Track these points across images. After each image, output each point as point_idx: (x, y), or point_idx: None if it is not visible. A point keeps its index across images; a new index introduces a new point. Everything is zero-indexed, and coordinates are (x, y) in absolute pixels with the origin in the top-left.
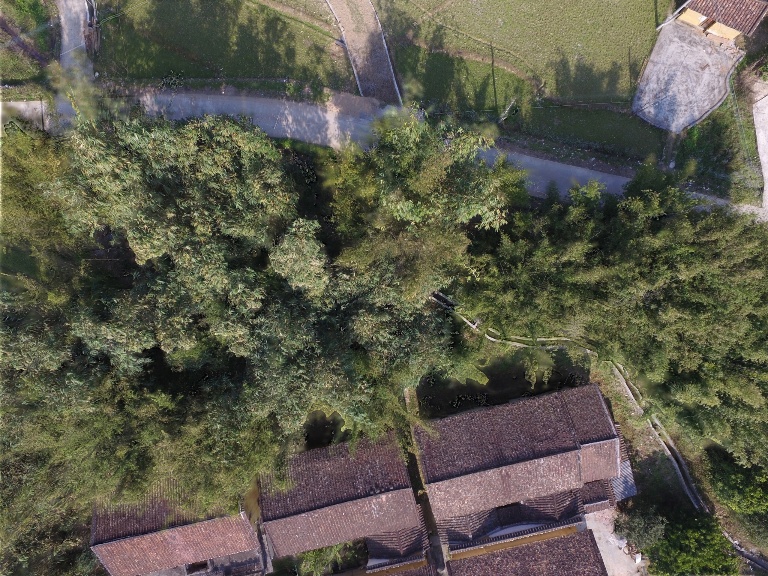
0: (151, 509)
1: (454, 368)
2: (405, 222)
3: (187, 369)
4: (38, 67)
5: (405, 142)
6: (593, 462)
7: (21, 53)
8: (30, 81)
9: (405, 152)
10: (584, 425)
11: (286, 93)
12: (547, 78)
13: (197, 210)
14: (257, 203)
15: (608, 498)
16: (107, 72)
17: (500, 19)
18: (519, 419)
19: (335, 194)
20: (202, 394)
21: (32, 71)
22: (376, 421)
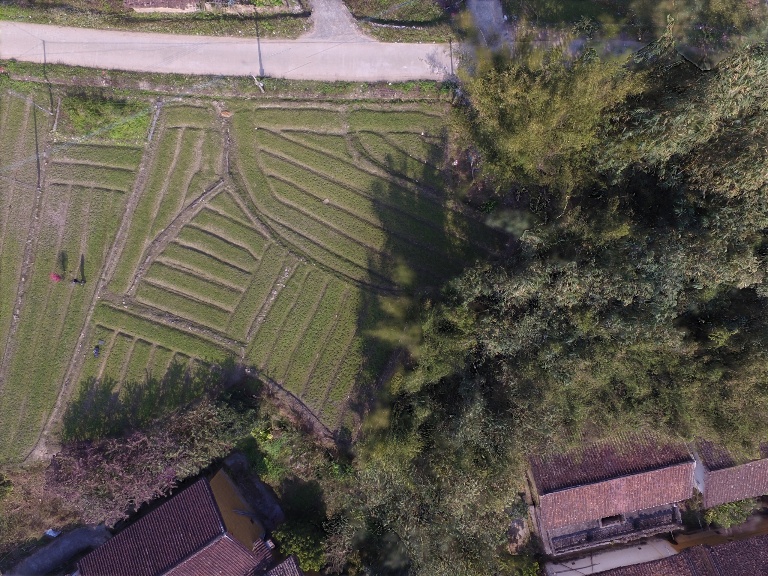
0: (594, 459)
1: None
2: None
3: (684, 313)
4: (440, 9)
5: None
6: None
7: None
8: (443, 22)
9: None
10: None
11: (704, 41)
12: None
13: None
14: None
15: None
16: (519, 15)
17: None
18: None
19: None
20: None
21: (434, 13)
22: None
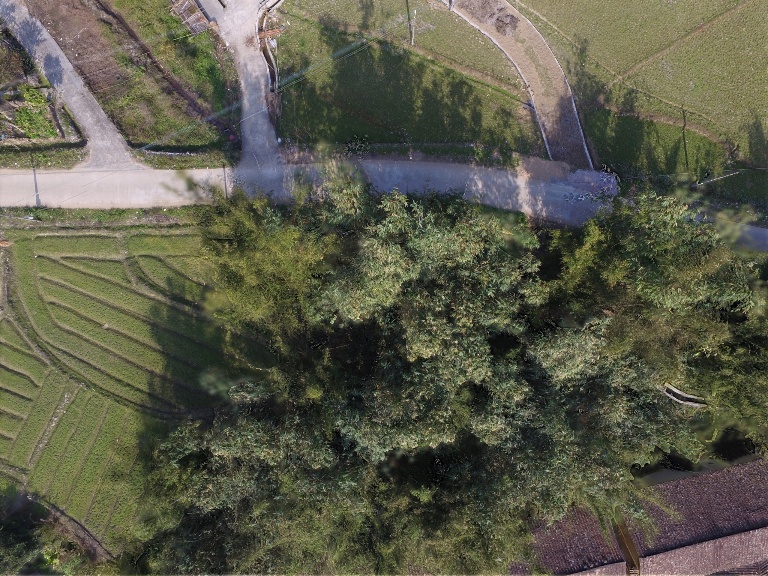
0: None
1: None
2: (664, 309)
3: (418, 453)
4: (217, 132)
5: (661, 227)
6: None
7: (199, 118)
8: (214, 149)
9: (660, 237)
10: None
11: (475, 158)
12: (740, 141)
13: (463, 303)
14: (513, 291)
15: None
16: (291, 138)
17: (691, 82)
18: (726, 487)
19: (568, 273)
20: (448, 482)
21: (211, 137)
22: (614, 503)
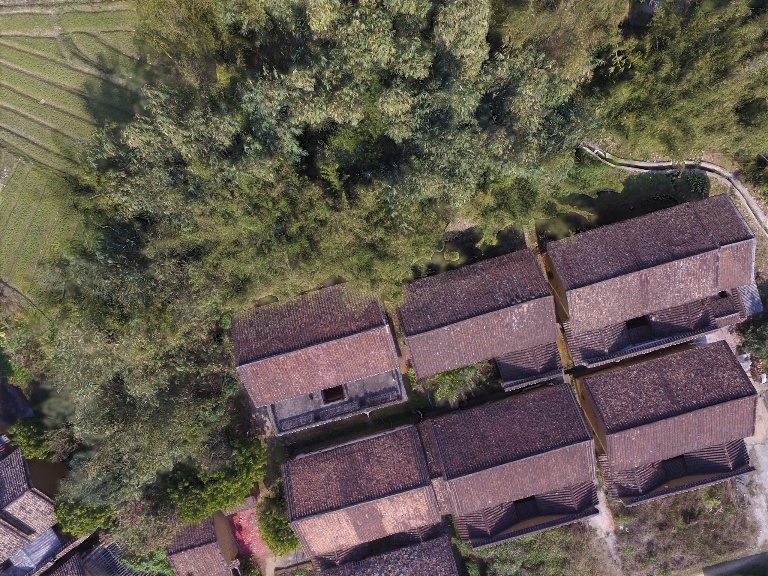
0: (293, 331)
1: (614, 142)
2: None
3: (338, 168)
4: None
5: None
6: (728, 268)
7: None
8: None
9: None
10: (719, 230)
11: None
12: None
13: None
14: None
15: (738, 311)
16: None
17: None
18: (653, 228)
19: None
20: (363, 181)
21: None
22: (530, 210)
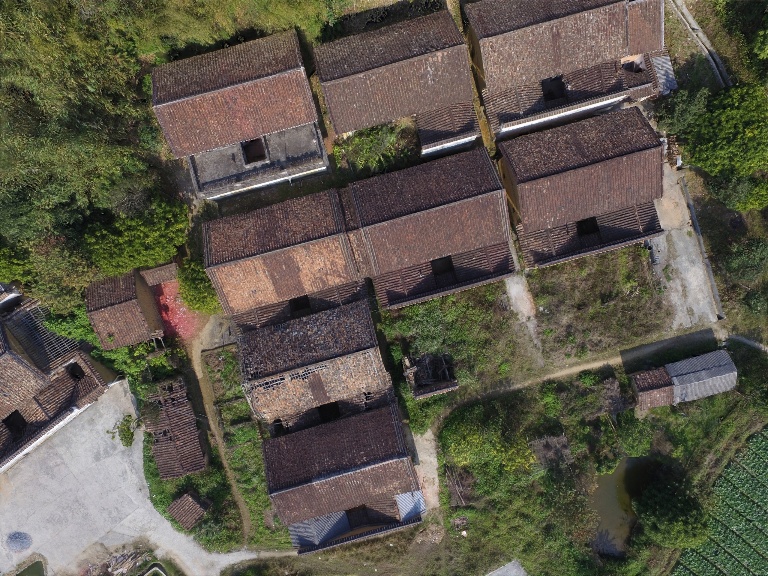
0: (211, 76)
1: None
2: None
3: None
4: None
5: None
6: (639, 28)
7: None
8: None
9: None
10: None
11: None
12: None
13: None
14: None
15: (651, 81)
16: None
17: None
18: None
19: None
20: None
21: None
22: None
